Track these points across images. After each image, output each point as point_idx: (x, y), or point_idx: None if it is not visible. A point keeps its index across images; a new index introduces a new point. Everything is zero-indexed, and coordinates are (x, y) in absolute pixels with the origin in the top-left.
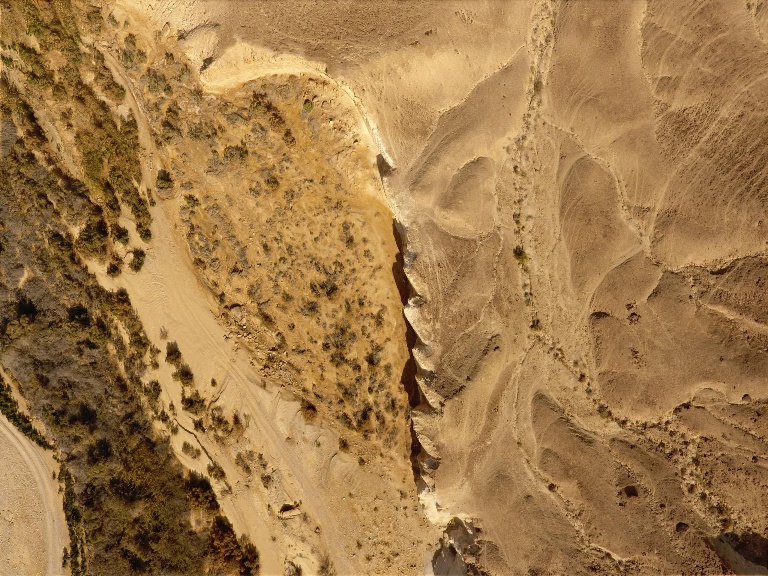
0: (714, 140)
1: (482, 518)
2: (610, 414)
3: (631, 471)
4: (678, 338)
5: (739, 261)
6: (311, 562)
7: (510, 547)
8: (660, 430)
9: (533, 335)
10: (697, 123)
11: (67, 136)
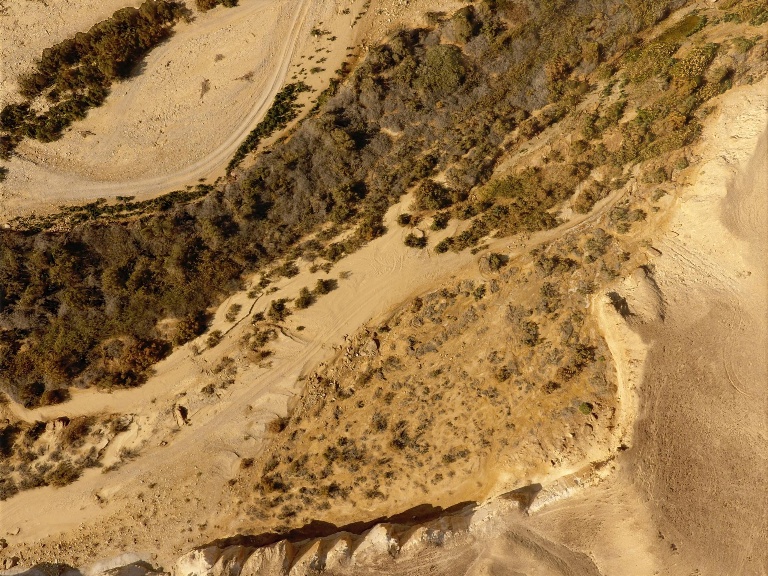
0: None
1: None
2: None
3: None
4: None
5: None
6: (134, 440)
7: None
8: None
9: None
10: None
11: (536, 159)
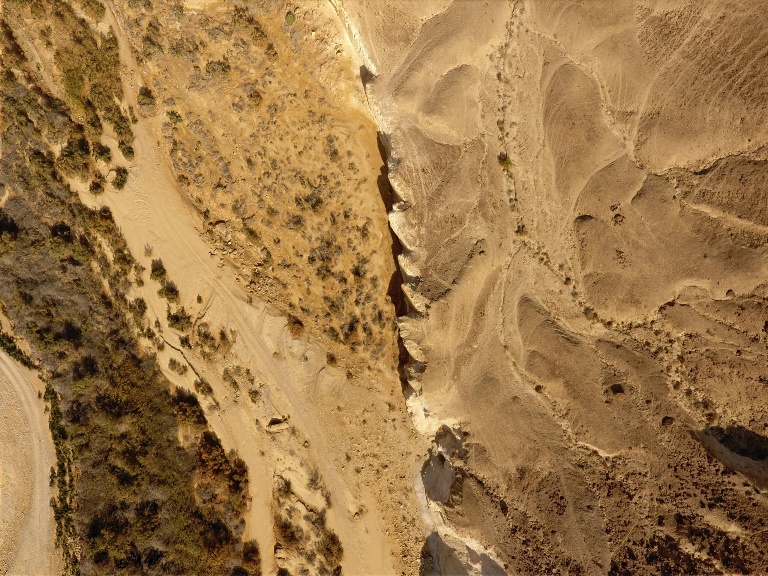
0: (696, 42)
1: (469, 421)
2: (596, 315)
3: (617, 370)
4: (662, 237)
5: (722, 160)
6: (300, 475)
7: (498, 447)
8: (645, 329)
9: (518, 240)
10: (679, 26)
11: (47, 55)
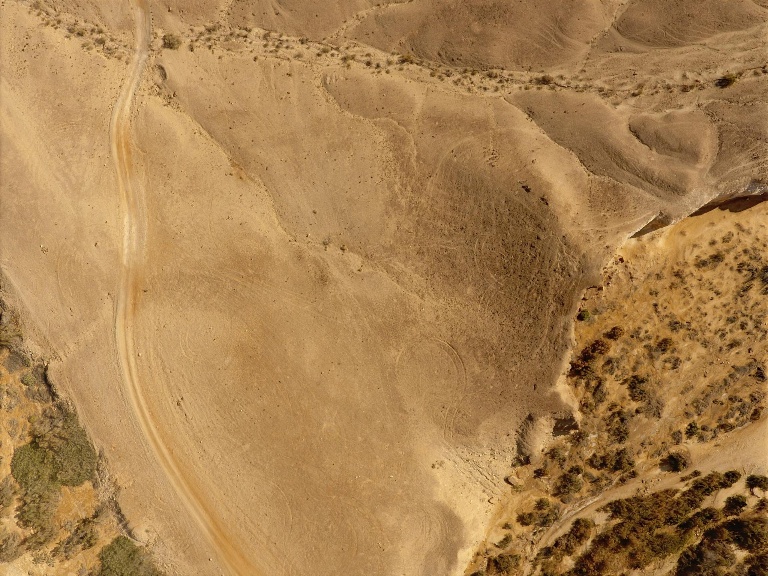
0: None
1: None
2: None
3: None
4: None
5: None
6: None
7: None
8: None
9: None
10: None
11: None
